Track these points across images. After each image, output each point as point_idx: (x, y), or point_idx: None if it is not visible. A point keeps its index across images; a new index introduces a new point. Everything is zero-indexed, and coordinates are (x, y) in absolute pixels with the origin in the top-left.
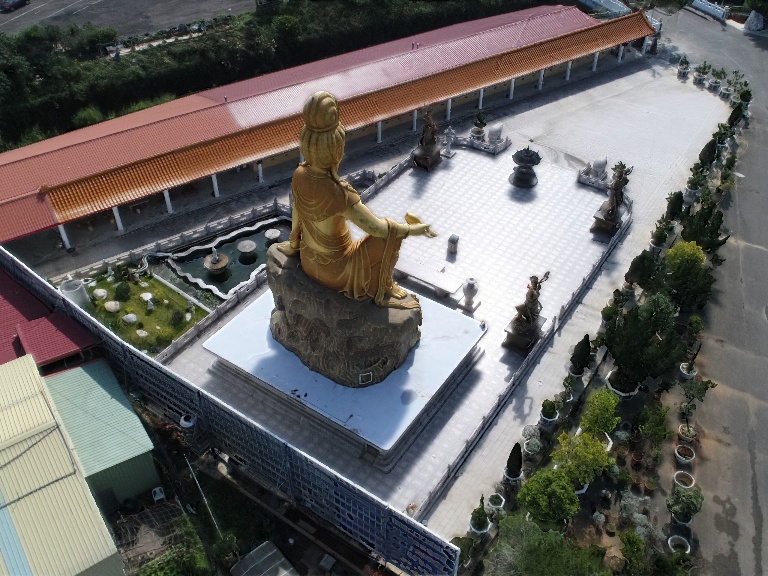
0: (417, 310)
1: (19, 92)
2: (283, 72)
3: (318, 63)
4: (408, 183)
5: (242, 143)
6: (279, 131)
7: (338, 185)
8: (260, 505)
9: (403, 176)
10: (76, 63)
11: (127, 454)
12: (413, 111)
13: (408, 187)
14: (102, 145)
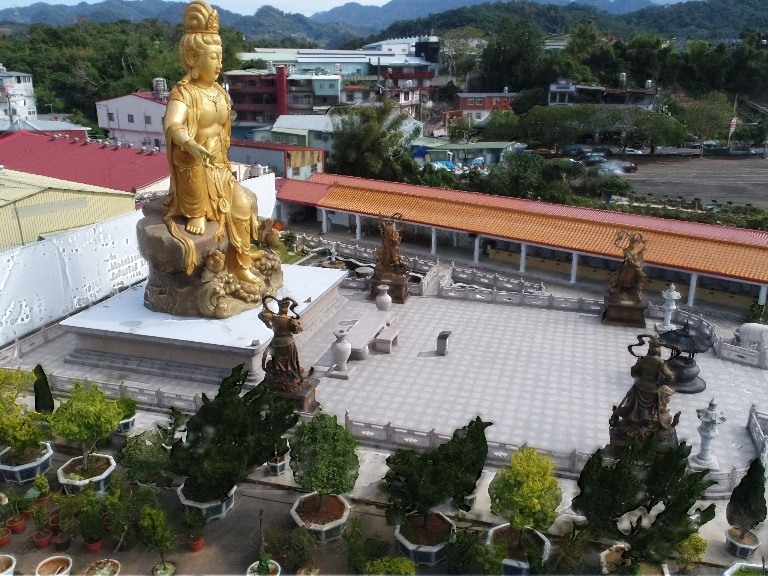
0: (179, 243)
1: None
2: None
3: None
4: (561, 317)
5: (473, 214)
6: (513, 220)
7: None
8: (46, 326)
9: (573, 313)
10: None
11: None
12: (690, 275)
13: (553, 317)
14: (418, 190)
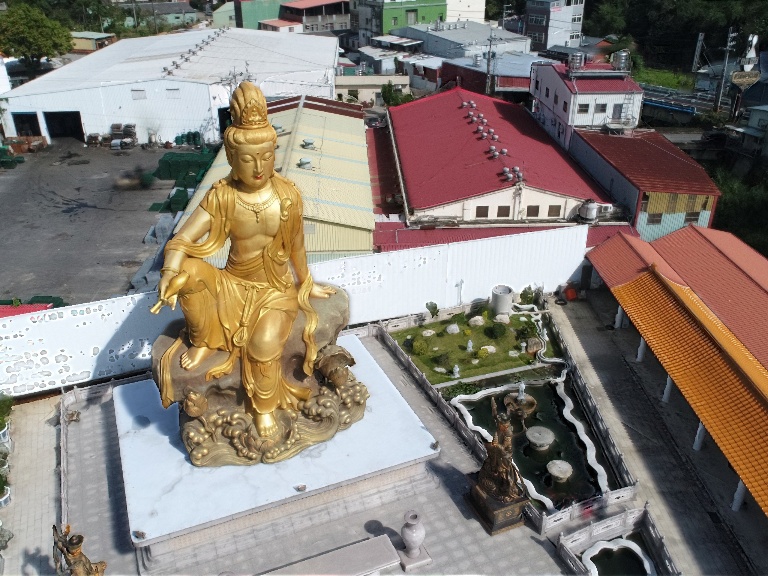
0: (159, 372)
1: None
2: None
3: None
4: None
5: (762, 431)
6: None
7: None
8: None
9: None
10: None
11: None
12: None
13: None
14: None
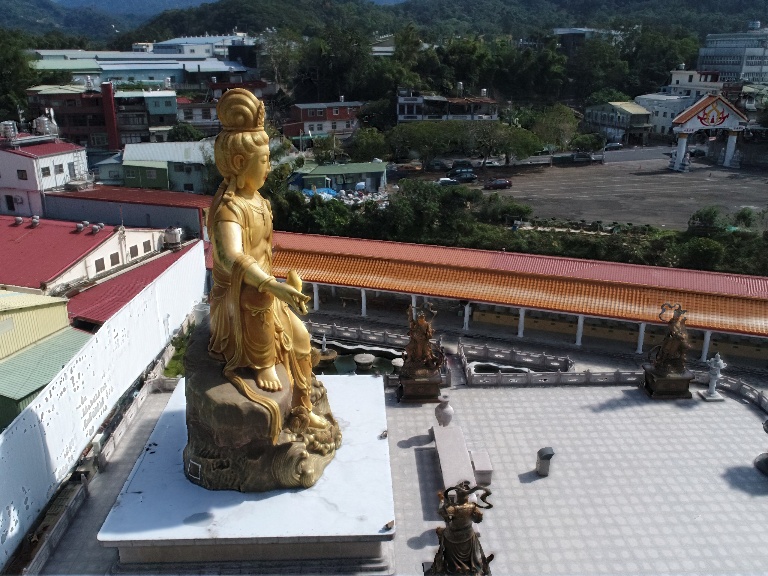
0: (261, 409)
1: (419, 229)
2: (612, 262)
3: (662, 267)
4: (608, 395)
5: (458, 278)
6: (505, 282)
7: (222, 196)
8: None
9: (613, 388)
10: (478, 223)
11: (2, 389)
12: (704, 332)
13: (601, 398)
14: (365, 245)
